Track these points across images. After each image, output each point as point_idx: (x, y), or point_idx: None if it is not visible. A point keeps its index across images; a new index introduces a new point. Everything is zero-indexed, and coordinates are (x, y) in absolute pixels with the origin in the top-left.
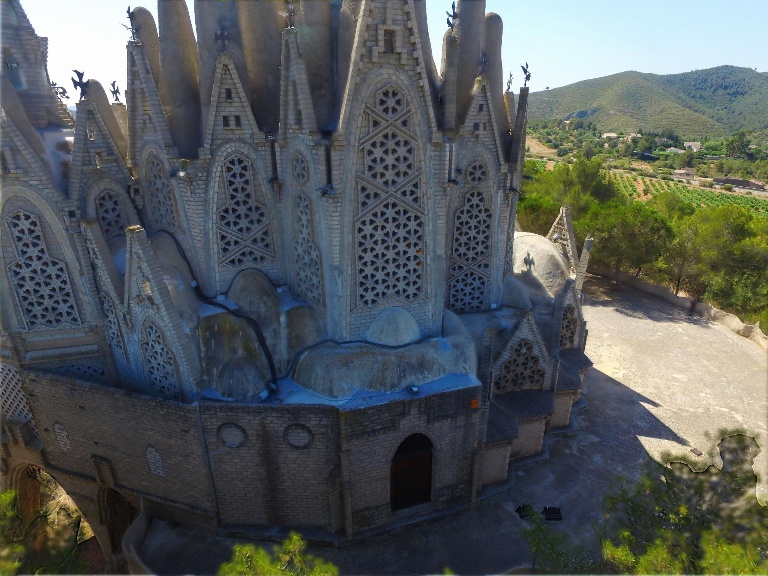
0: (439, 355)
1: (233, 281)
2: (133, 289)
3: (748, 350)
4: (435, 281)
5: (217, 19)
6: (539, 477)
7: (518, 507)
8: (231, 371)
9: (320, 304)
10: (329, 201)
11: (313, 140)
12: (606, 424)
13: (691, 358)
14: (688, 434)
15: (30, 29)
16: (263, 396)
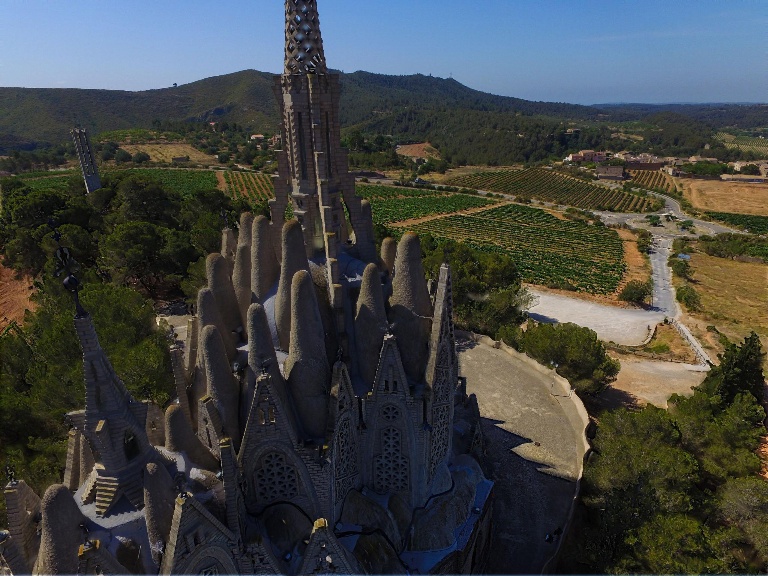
0: (470, 479)
1: (343, 509)
2: (309, 568)
3: (505, 358)
4: (450, 434)
5: (318, 334)
6: (498, 507)
7: (548, 539)
8: (390, 575)
9: (407, 490)
10: (424, 430)
11: (413, 399)
12: (495, 450)
13: (490, 378)
14: (527, 434)
15: (128, 394)
16: (409, 575)
